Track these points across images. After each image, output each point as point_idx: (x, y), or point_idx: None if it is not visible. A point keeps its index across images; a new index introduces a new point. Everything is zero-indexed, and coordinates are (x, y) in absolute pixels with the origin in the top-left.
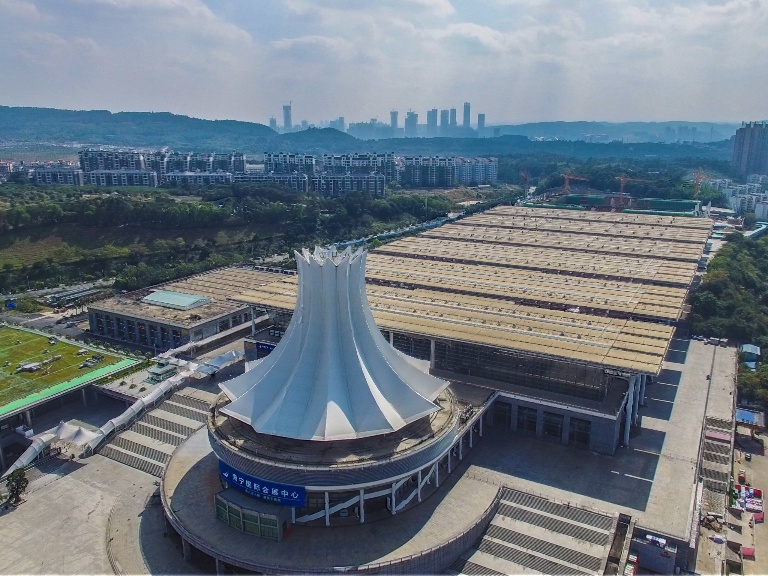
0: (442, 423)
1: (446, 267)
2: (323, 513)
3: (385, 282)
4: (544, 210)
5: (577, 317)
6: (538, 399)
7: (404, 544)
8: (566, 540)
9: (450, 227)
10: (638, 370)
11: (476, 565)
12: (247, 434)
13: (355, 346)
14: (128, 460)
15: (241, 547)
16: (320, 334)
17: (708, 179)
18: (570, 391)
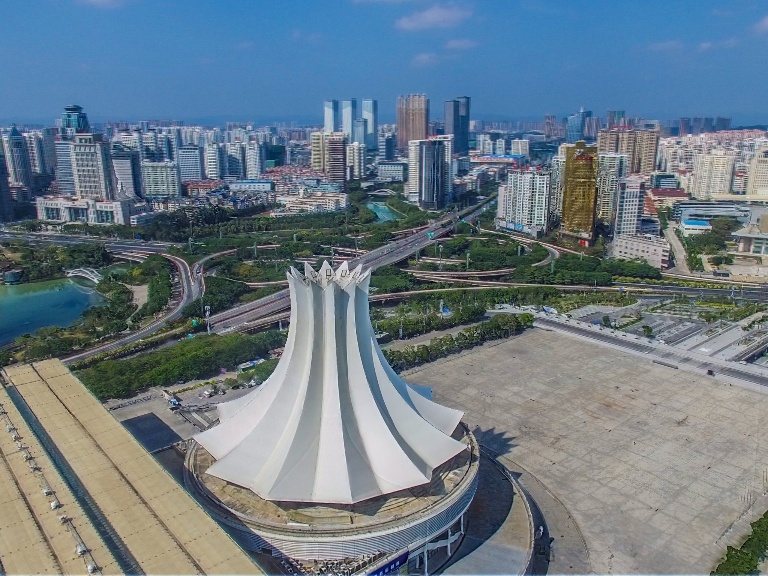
0: None
1: None
2: None
3: None
4: None
5: None
6: None
7: None
8: None
9: None
10: None
11: None
12: None
13: None
14: None
15: None
16: None
17: None
18: None
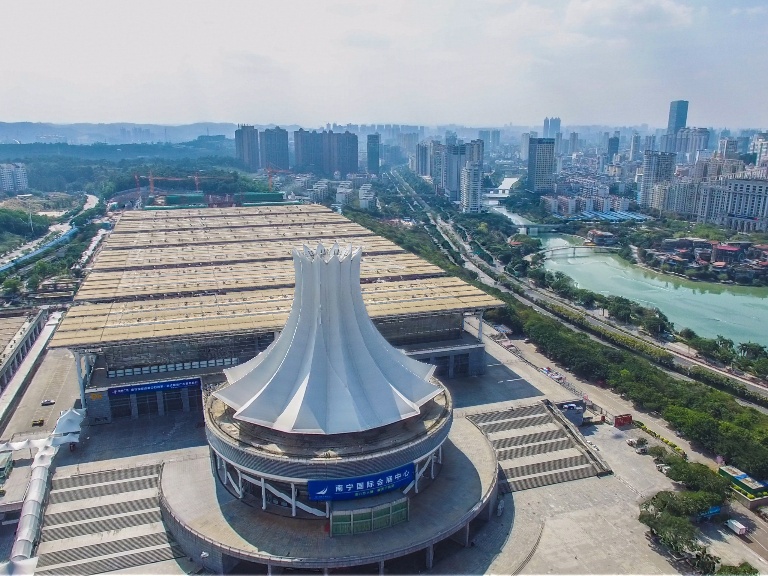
0: (432, 379)
1: (212, 270)
2: (413, 484)
3: (185, 294)
4: (178, 211)
5: (395, 284)
6: (429, 349)
7: (479, 475)
8: (533, 429)
9: (123, 236)
10: (495, 305)
11: (511, 469)
12: (324, 445)
13: (374, 332)
14: (94, 568)
15: (391, 541)
16: (344, 329)
17: (287, 173)
18: (440, 338)
